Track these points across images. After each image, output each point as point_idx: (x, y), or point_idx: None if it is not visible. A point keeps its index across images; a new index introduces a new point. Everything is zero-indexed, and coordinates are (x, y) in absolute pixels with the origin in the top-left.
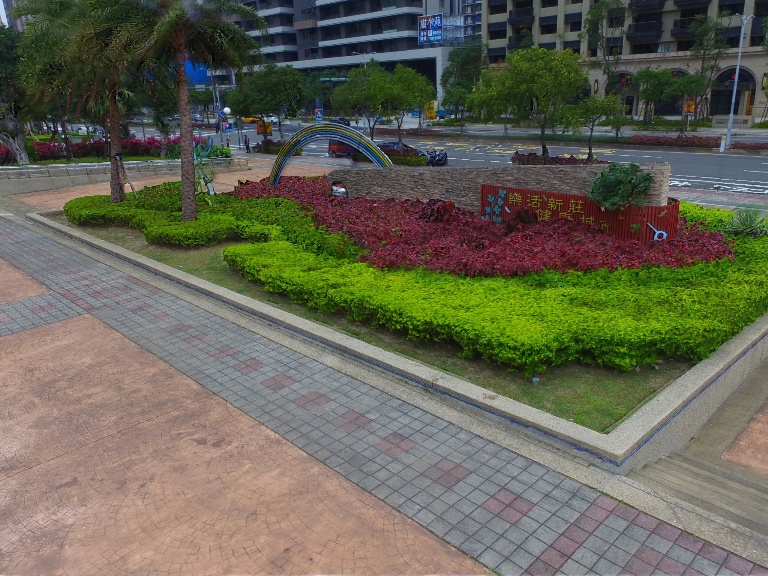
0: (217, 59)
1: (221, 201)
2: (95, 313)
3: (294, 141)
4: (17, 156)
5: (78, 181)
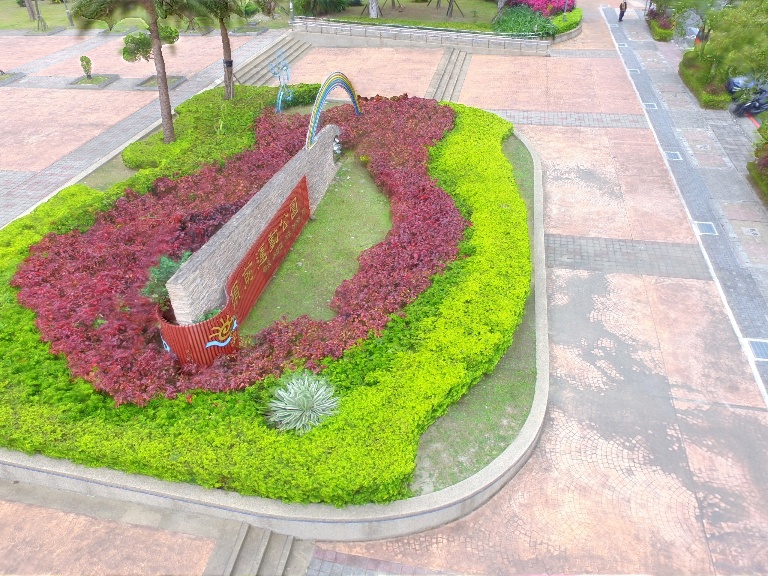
0: (192, 16)
1: (229, 128)
2: (1, 198)
3: (344, 80)
4: (370, 5)
5: (372, 43)
